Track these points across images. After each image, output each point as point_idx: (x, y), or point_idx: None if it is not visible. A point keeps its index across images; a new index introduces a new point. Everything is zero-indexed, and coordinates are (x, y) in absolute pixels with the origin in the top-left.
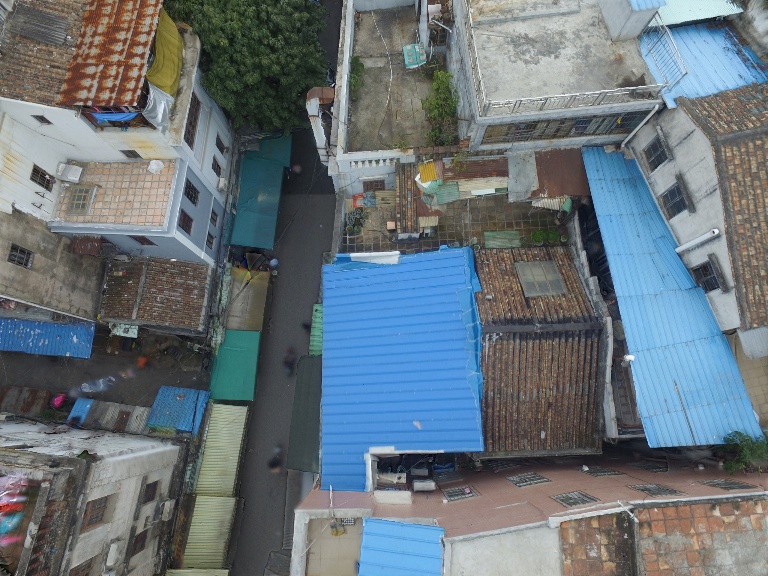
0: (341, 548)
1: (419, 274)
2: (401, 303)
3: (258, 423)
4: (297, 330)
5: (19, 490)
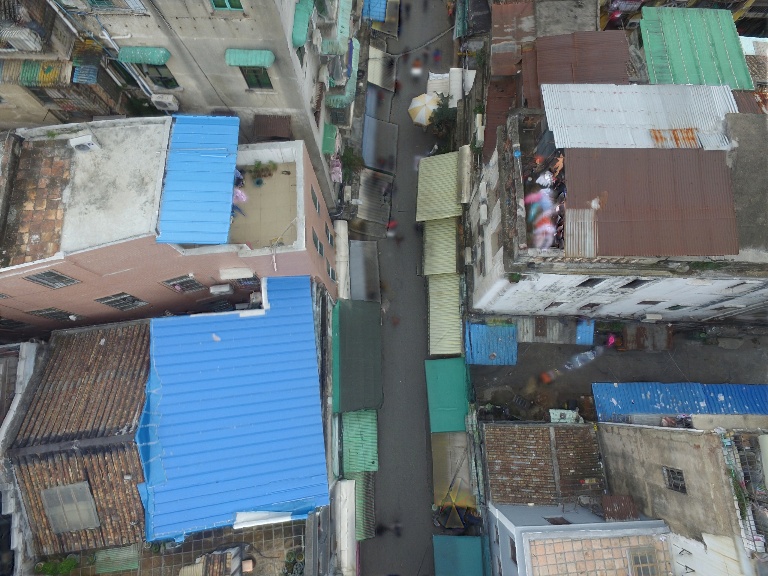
0: (274, 230)
1: (211, 501)
2: (233, 463)
3: (424, 343)
4: (400, 441)
5: (555, 242)
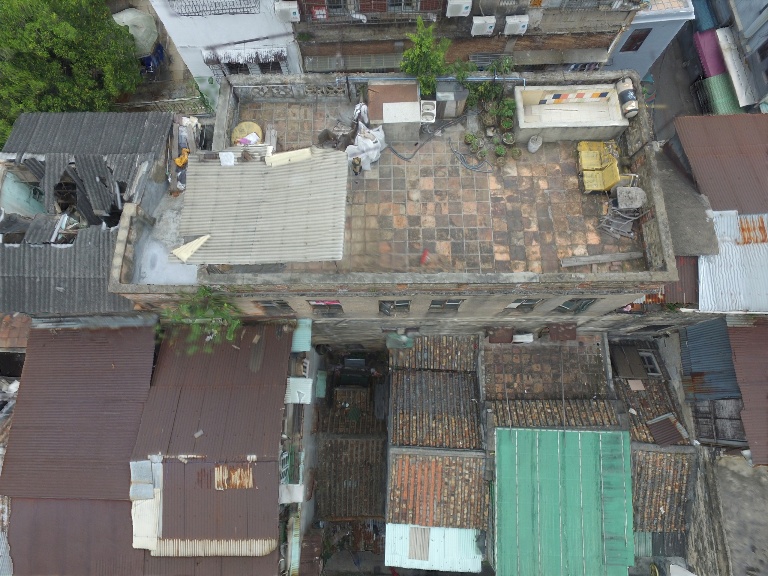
0: None
1: None
2: None
3: None
4: None
5: None
